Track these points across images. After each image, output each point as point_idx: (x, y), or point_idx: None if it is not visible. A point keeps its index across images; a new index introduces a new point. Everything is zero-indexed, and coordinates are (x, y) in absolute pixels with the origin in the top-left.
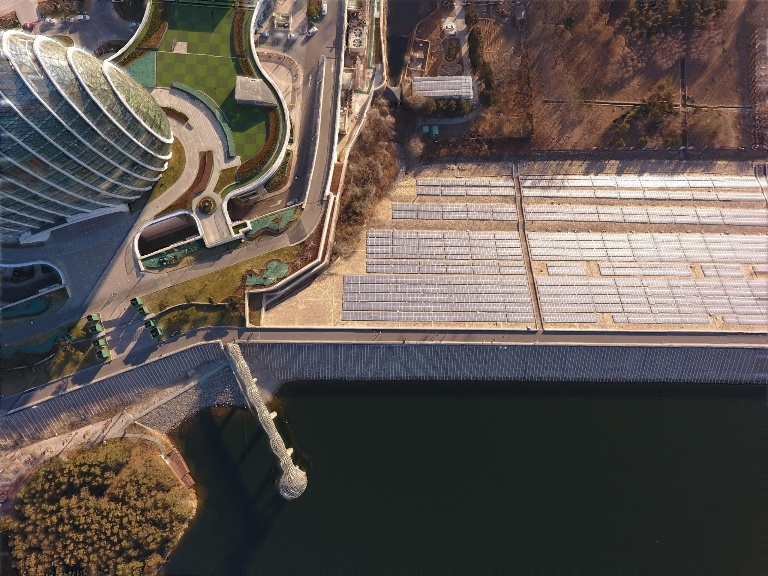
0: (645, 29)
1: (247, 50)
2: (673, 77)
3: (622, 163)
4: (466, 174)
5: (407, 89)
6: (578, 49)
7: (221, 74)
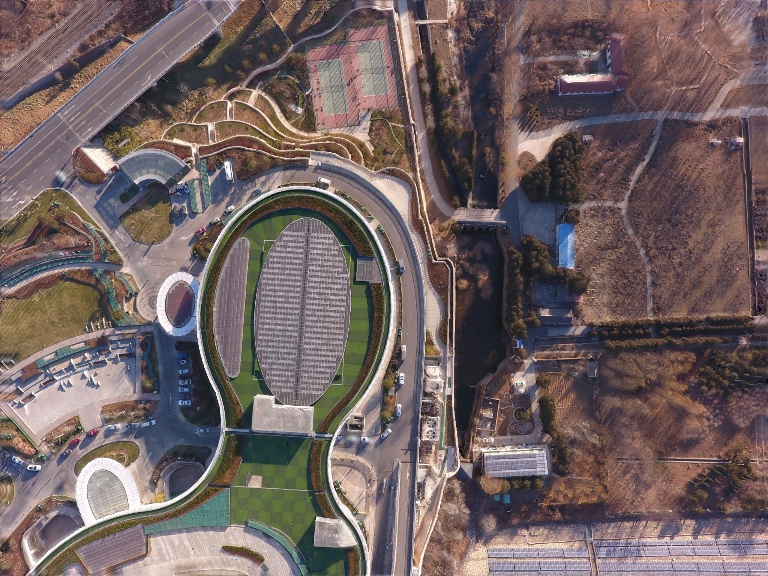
0: (722, 389)
1: (324, 483)
2: (749, 431)
3: (698, 524)
4: (538, 540)
5: (478, 457)
6: (651, 403)
7: (297, 510)
